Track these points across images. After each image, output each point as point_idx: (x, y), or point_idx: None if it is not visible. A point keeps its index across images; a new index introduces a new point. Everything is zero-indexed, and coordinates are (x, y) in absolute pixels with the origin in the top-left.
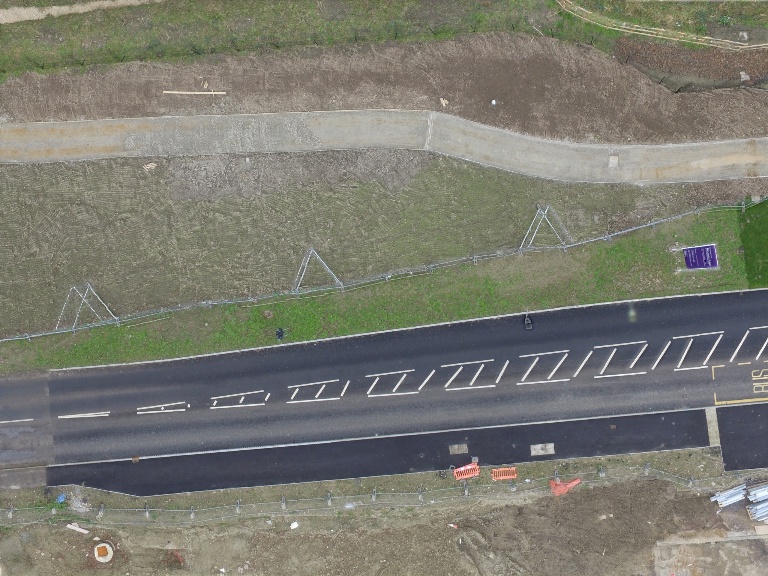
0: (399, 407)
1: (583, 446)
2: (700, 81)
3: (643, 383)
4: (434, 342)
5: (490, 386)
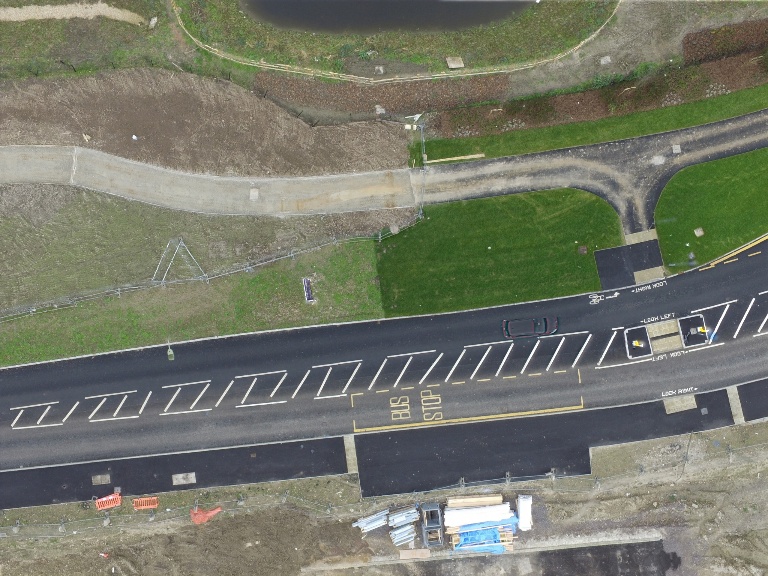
0: (44, 439)
1: (224, 475)
2: (337, 115)
3: (283, 412)
4: (78, 374)
5: (133, 417)
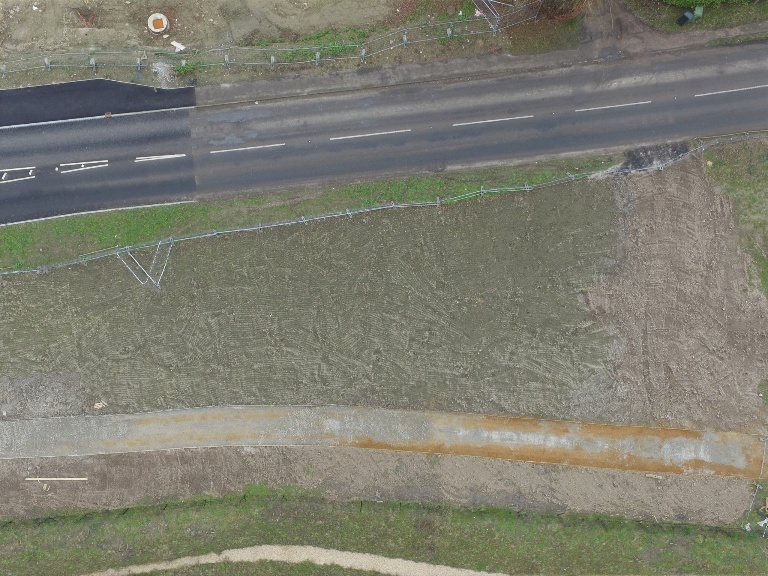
0: None
1: None
2: None
3: None
4: None
5: None
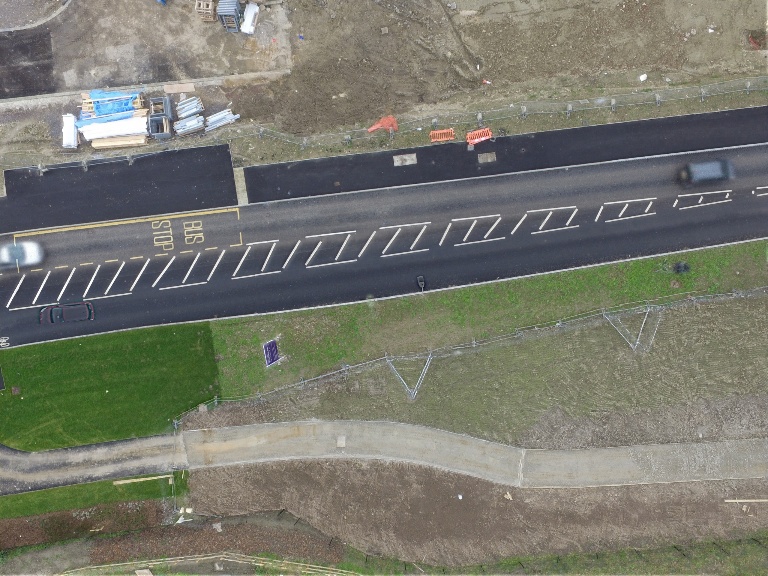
0: (546, 197)
1: (366, 164)
2: (260, 522)
3: (309, 227)
4: (513, 261)
5: (457, 220)
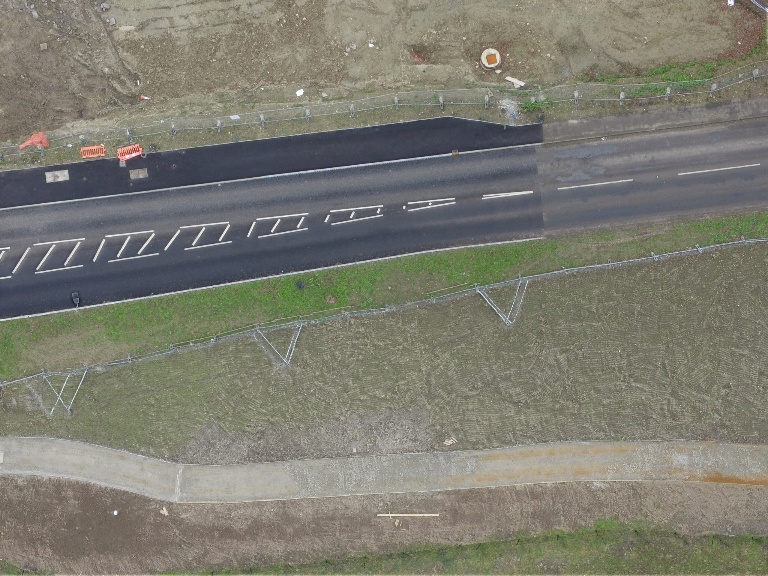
0: (199, 213)
1: (18, 181)
2: None
3: None
4: (167, 277)
5: (111, 236)
